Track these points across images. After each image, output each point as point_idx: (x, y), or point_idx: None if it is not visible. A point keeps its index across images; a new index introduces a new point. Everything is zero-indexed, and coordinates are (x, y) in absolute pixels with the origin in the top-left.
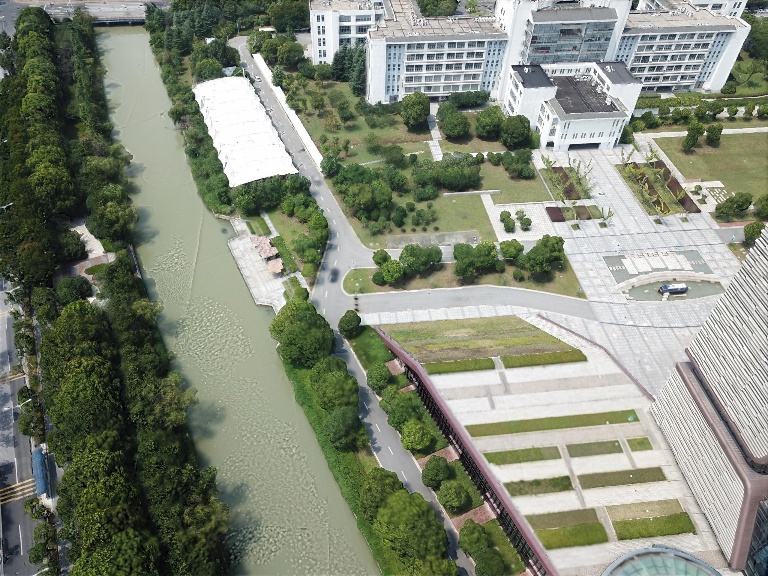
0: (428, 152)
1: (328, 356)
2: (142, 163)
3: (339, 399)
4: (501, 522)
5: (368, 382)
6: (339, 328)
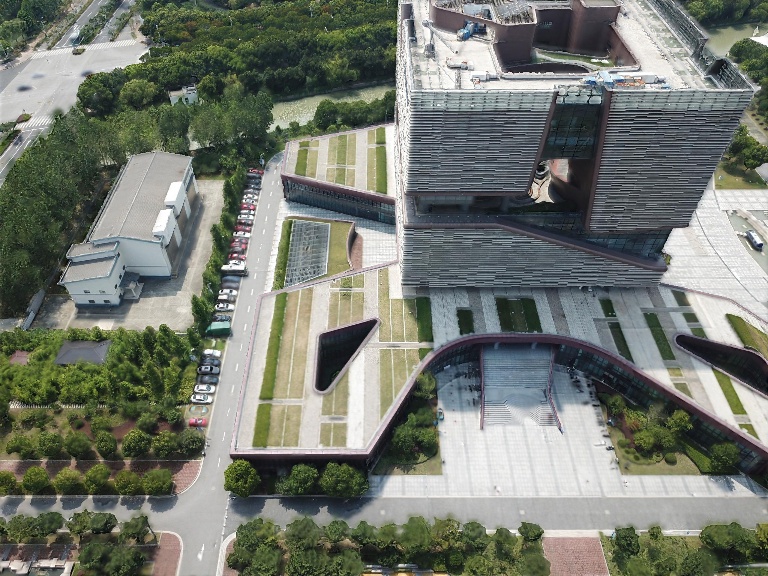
0: None
1: None
2: None
3: None
4: None
5: None
6: None
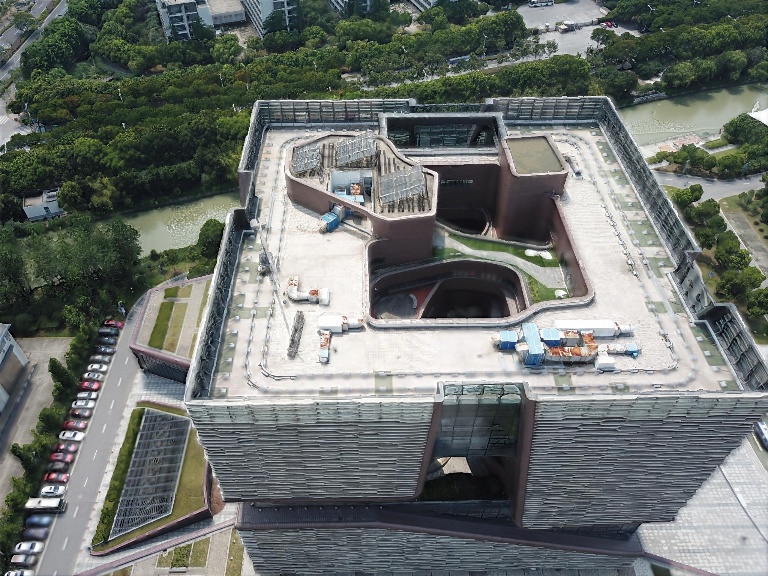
0: None
1: None
2: None
3: None
4: None
5: None
6: None
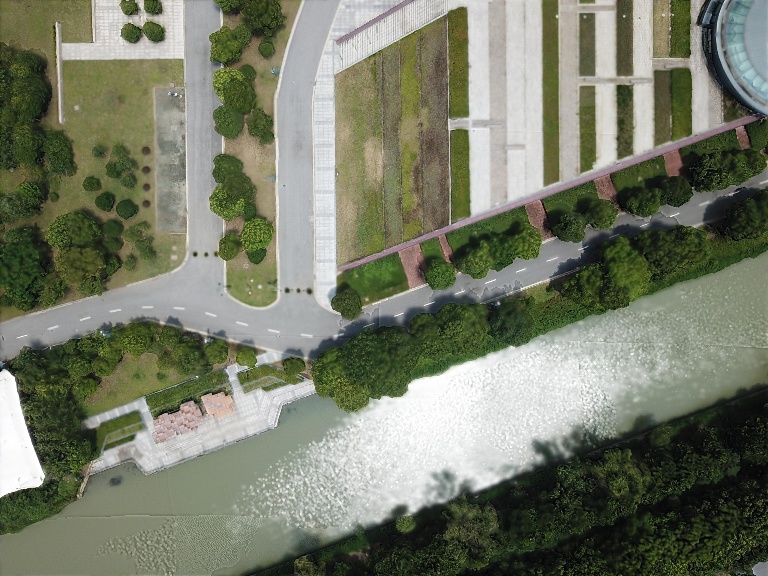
0: None
1: (417, 338)
2: None
3: (484, 328)
4: None
5: None
6: None
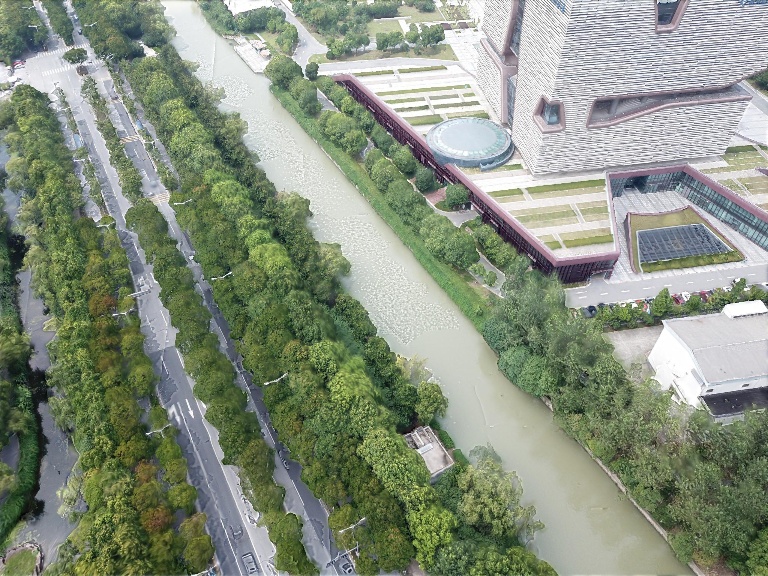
0: (365, 2)
1: None
2: (171, 16)
3: None
4: (395, 136)
5: (323, 90)
6: (306, 72)
